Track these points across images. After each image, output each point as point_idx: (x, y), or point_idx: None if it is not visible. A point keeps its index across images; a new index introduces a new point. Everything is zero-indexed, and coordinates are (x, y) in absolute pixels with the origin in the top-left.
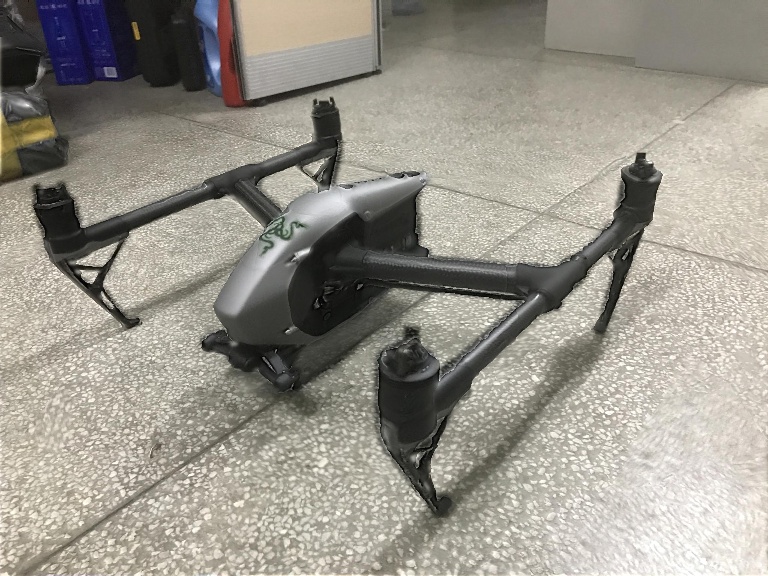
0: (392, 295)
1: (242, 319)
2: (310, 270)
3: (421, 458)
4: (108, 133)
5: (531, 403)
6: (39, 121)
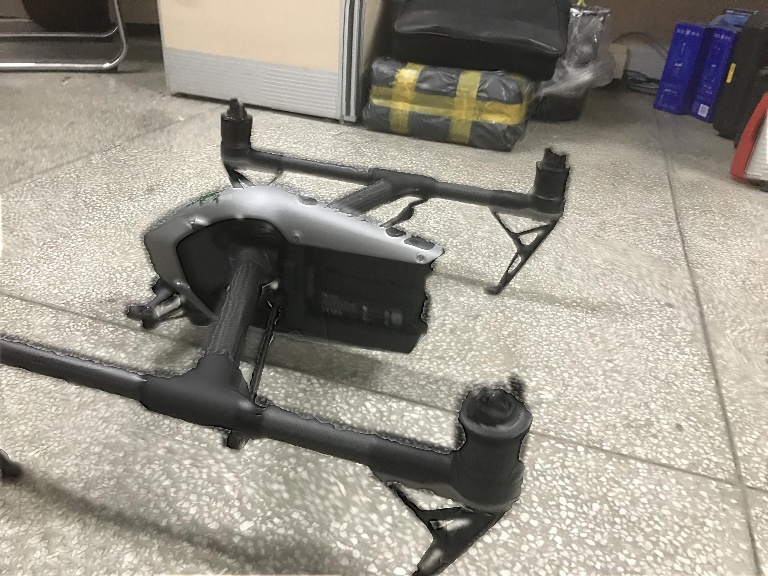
0: (389, 372)
1: (149, 244)
2: (213, 246)
3: None
4: (591, 147)
5: (192, 526)
6: (502, 104)
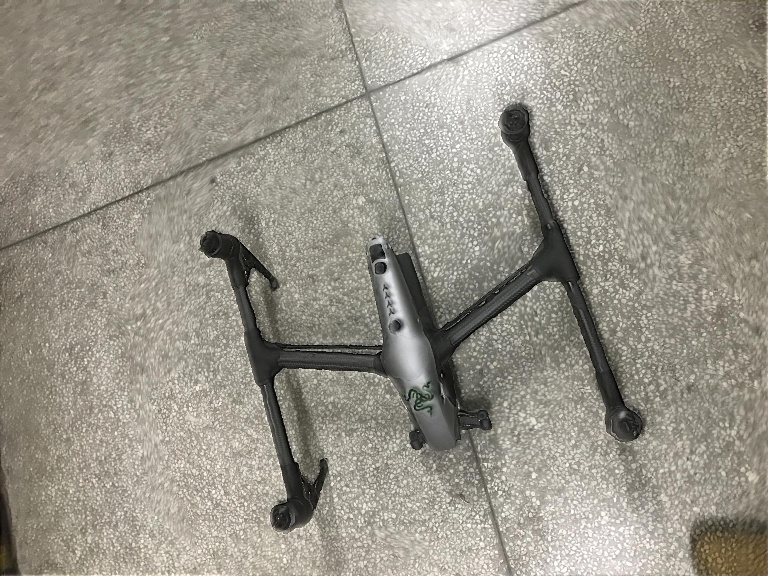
0: None
1: None
2: None
3: None
4: None
5: None
6: None
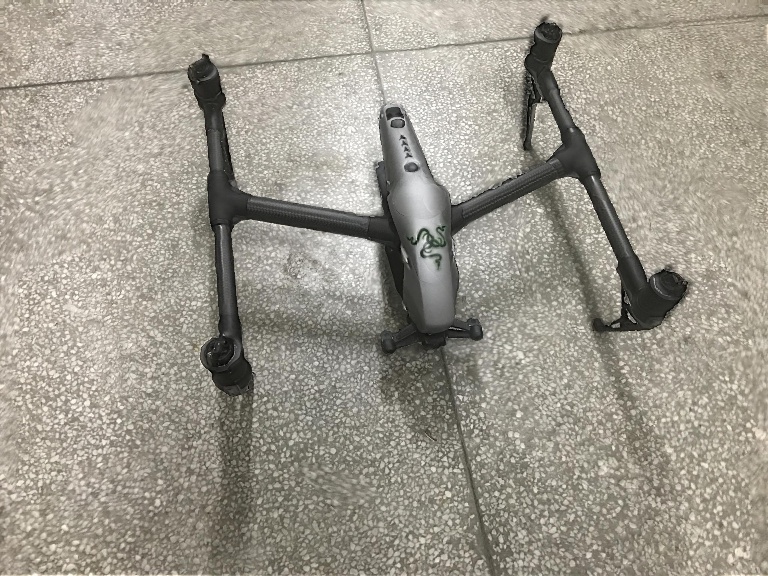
0: None
1: None
2: None
3: (624, 316)
4: None
5: (558, 229)
6: None
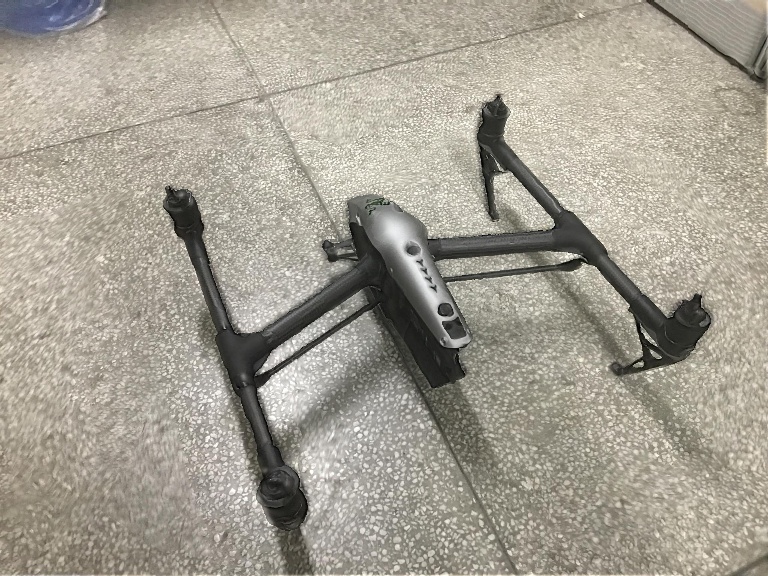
0: None
1: None
2: None
3: None
4: None
5: None
6: None
